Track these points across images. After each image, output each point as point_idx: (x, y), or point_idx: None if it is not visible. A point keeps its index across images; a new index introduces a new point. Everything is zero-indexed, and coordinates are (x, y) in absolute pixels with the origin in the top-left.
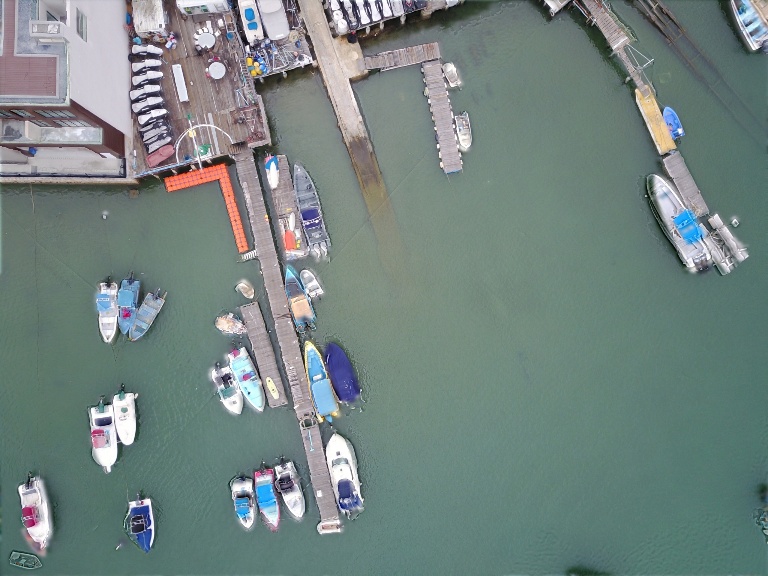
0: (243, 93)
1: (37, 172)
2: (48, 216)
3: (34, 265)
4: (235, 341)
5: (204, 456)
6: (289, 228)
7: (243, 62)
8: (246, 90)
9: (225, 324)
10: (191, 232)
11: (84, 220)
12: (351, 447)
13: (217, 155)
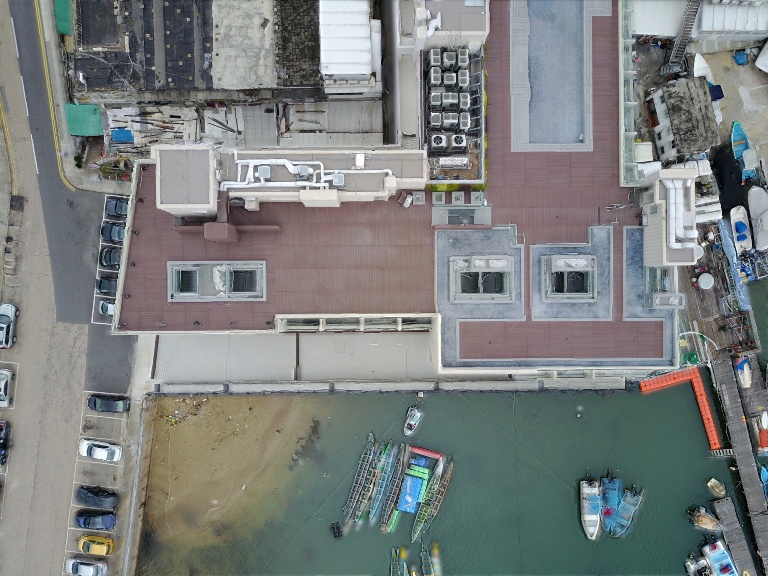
0: (727, 301)
1: (545, 387)
2: (525, 415)
3: (514, 463)
4: (708, 535)
5: None
6: (762, 426)
7: (729, 271)
8: (730, 298)
9: (709, 523)
10: (659, 428)
11: (557, 418)
12: None
13: (702, 361)
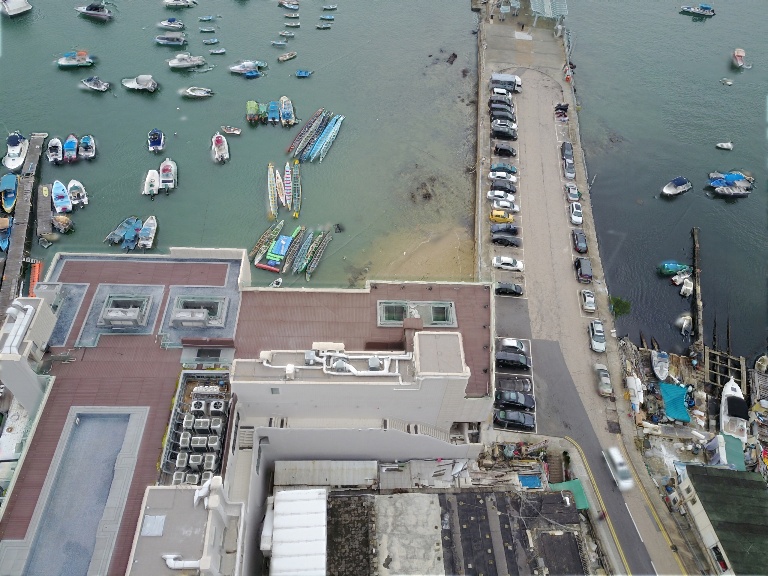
0: None
1: None
2: None
3: None
4: None
5: (111, 169)
6: None
7: None
8: None
9: (61, 219)
10: None
11: None
12: (3, 162)
13: None
